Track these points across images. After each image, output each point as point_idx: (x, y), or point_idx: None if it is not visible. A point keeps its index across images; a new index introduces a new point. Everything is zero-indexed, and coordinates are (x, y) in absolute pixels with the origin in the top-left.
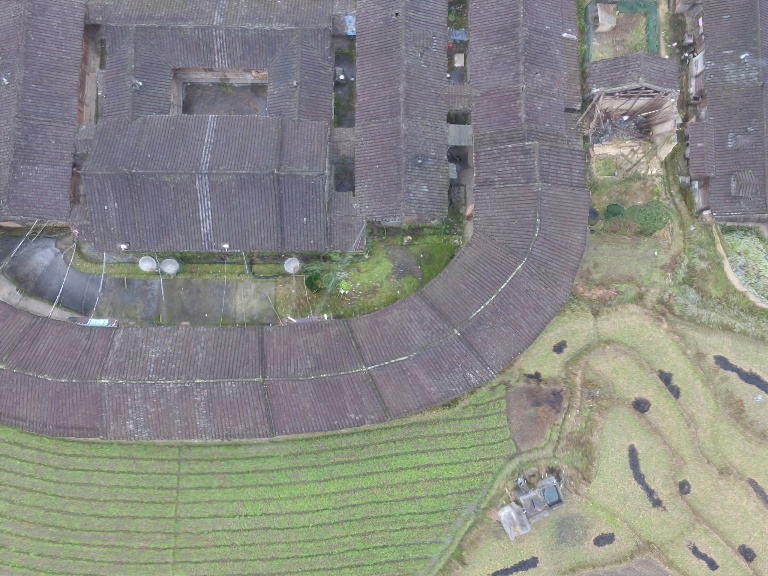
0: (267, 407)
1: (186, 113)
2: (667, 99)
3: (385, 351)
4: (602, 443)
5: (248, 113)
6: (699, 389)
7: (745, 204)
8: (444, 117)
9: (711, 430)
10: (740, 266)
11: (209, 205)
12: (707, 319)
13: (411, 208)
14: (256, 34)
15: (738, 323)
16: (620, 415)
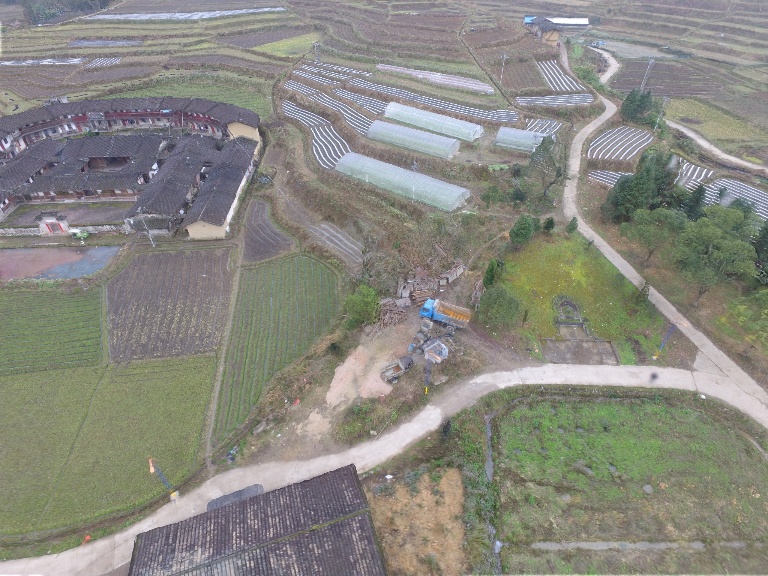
0: None
1: None
2: None
3: (72, 105)
4: None
5: None
6: None
7: None
8: None
9: None
10: None
11: None
12: None
13: None
14: None
15: None
16: None
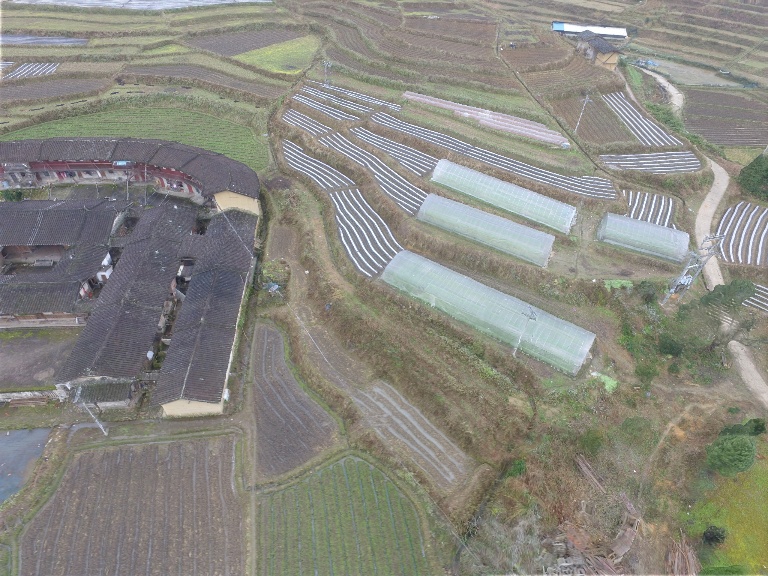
0: None
1: None
2: None
3: None
4: None
5: None
6: None
7: None
8: None
9: None
10: None
11: None
12: None
13: None
14: None
15: None
16: None
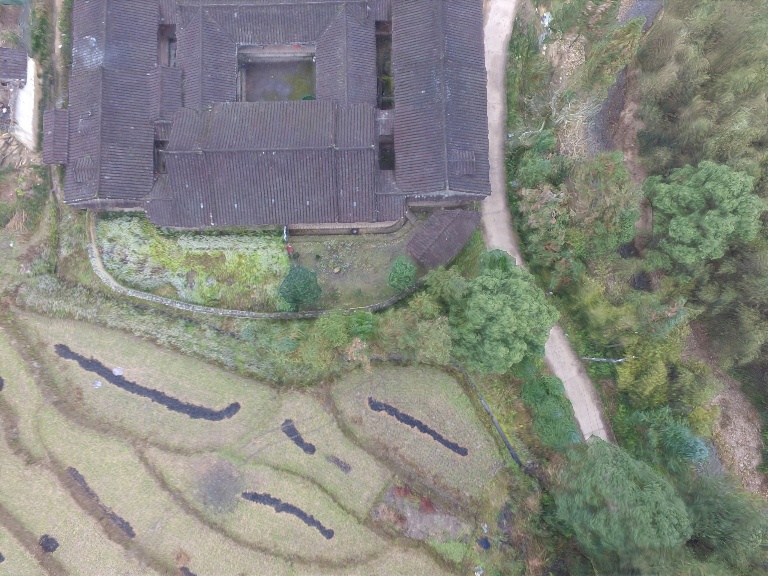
0: None
1: None
2: None
3: None
4: None
5: None
6: (23, 380)
7: (85, 190)
8: None
9: (32, 421)
10: (108, 252)
11: None
12: (49, 308)
13: None
14: None
15: (80, 310)
16: None
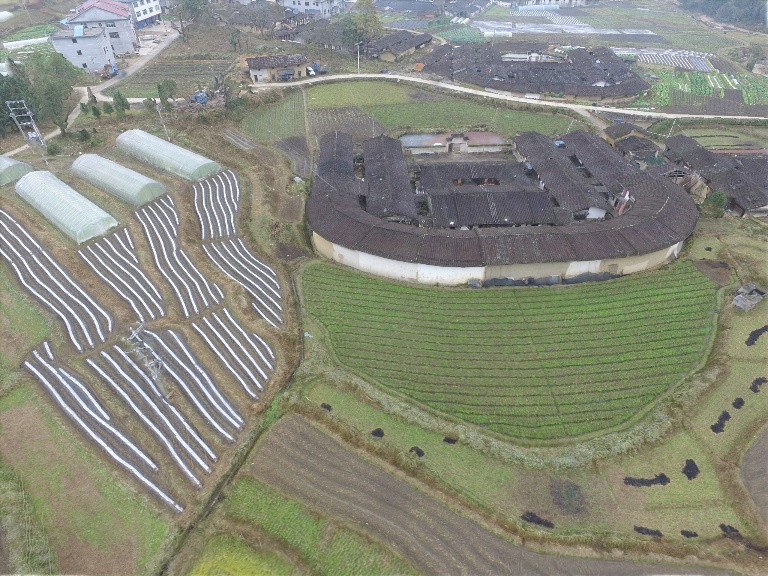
0: (571, 245)
1: None
2: (691, 176)
3: None
4: (767, 275)
5: None
6: None
7: (760, 202)
8: None
9: None
10: None
11: (494, 205)
12: None
13: None
14: (489, 166)
15: None
16: (767, 265)
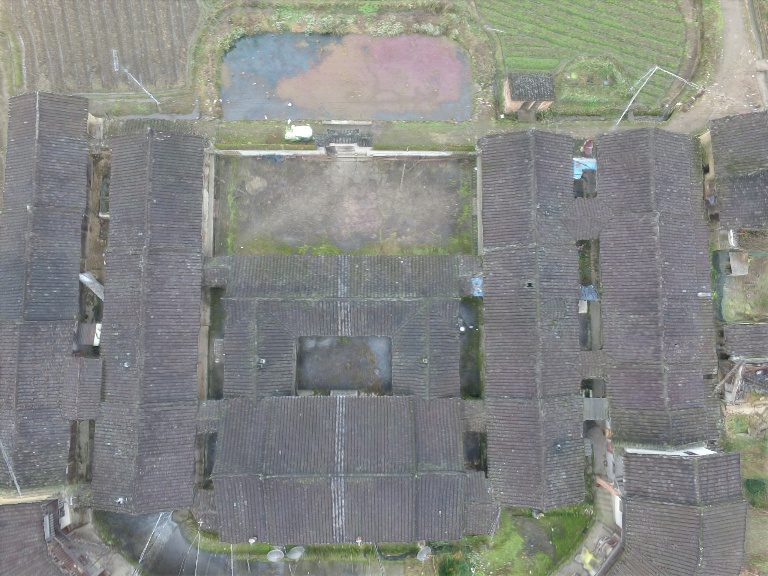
0: None
1: (300, 366)
2: None
3: None
4: None
5: (364, 365)
6: None
7: None
8: (577, 389)
9: None
10: None
11: (343, 503)
12: None
13: (551, 500)
14: (382, 305)
15: None
16: None
